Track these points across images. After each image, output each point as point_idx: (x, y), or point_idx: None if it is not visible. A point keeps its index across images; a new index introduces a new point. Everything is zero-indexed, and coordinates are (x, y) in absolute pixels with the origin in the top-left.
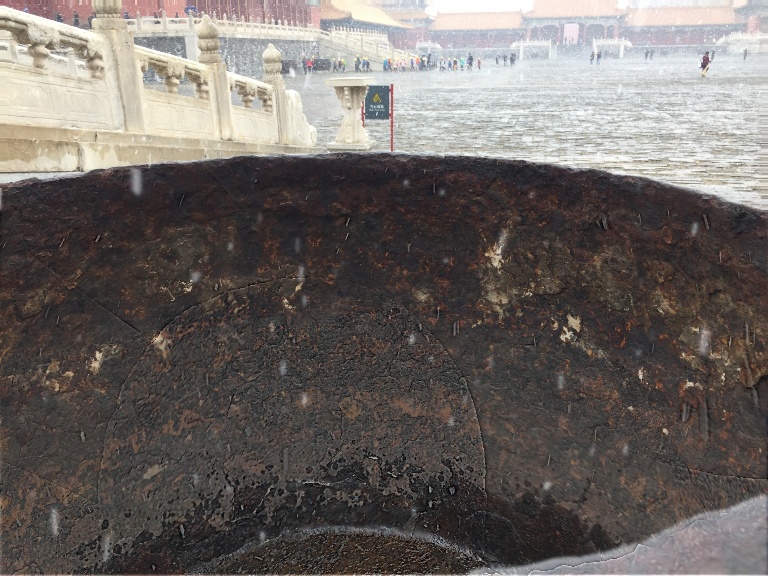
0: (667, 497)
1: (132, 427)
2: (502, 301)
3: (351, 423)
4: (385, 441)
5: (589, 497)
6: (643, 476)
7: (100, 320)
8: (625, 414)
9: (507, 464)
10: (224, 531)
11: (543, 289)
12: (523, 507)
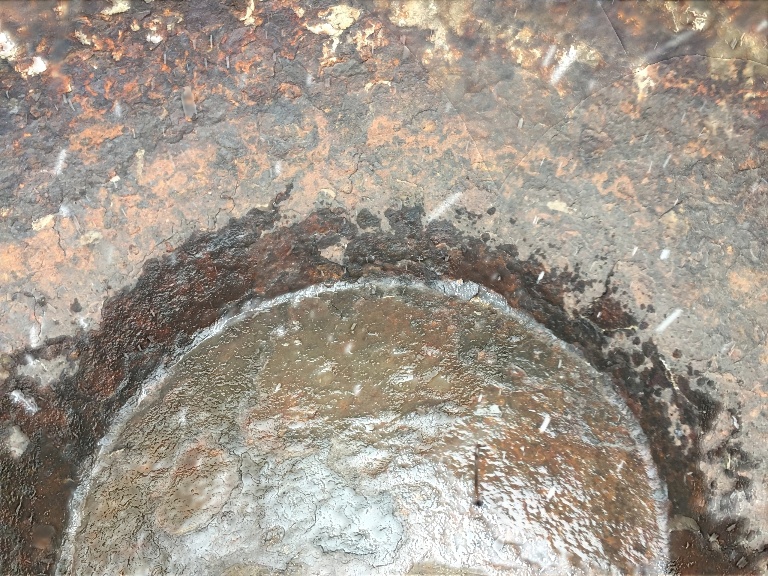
0: None
1: (568, 150)
2: None
3: (761, 361)
4: (766, 423)
5: None
6: None
7: (588, 10)
8: None
9: None
10: (569, 315)
11: None
12: None
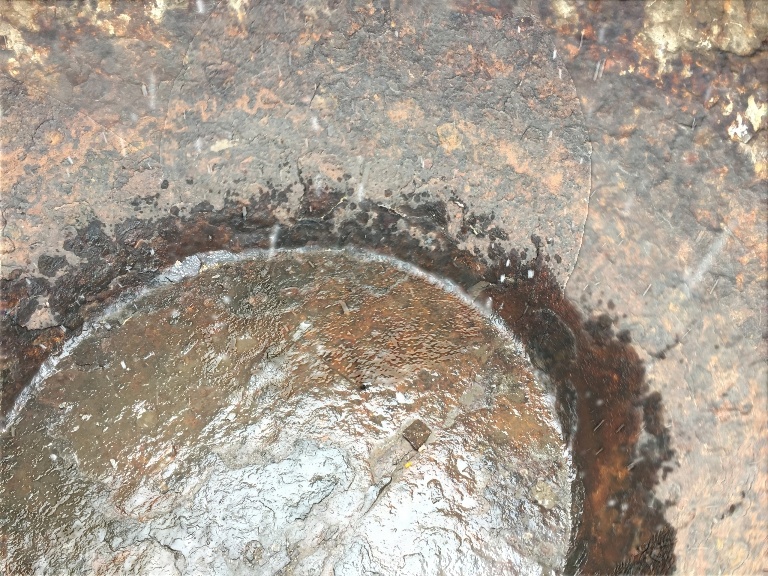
0: (749, 414)
1: (201, 93)
2: (668, 45)
3: (446, 155)
4: (478, 189)
5: (668, 357)
6: (738, 371)
7: None
8: (762, 279)
9: (599, 271)
10: (287, 226)
11: (728, 42)
12: (595, 328)
